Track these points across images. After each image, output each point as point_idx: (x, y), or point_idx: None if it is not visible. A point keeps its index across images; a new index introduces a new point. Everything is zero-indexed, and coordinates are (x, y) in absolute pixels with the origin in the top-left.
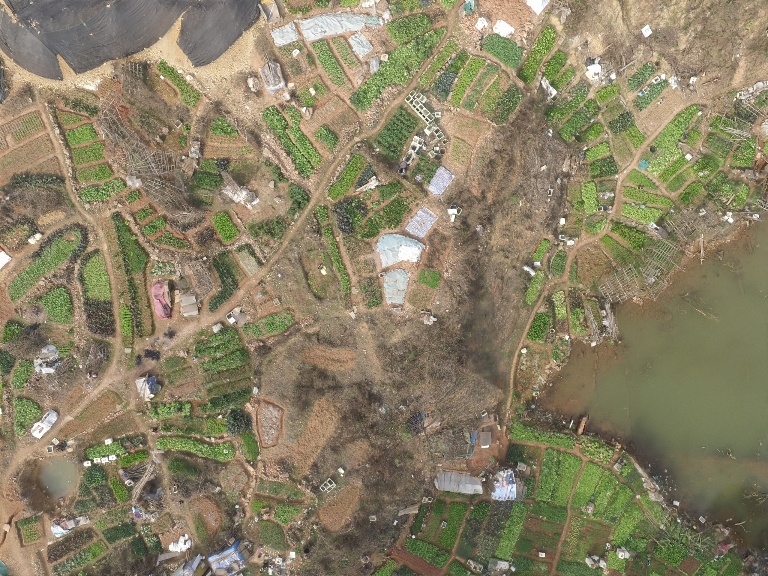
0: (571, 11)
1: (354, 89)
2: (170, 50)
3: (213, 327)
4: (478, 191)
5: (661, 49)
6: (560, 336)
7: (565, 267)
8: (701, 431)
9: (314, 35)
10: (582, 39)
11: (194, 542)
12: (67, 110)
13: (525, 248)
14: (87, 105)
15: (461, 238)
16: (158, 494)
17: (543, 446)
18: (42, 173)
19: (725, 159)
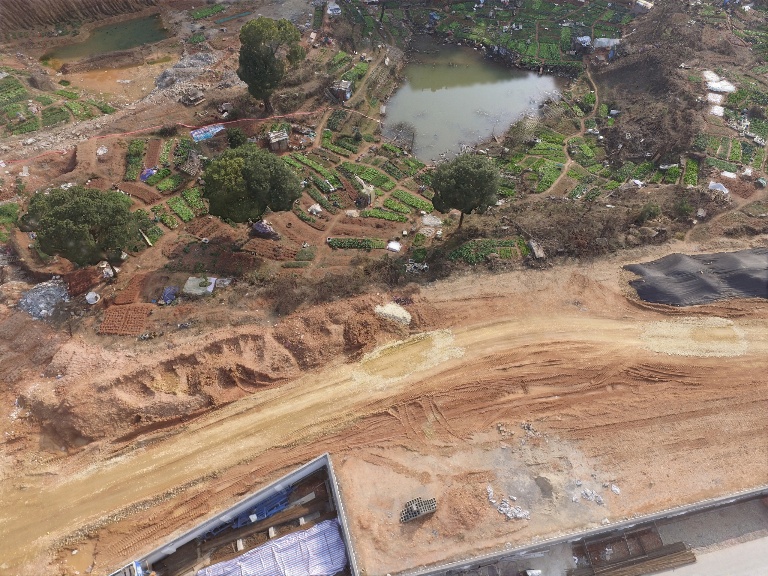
0: None
1: None
2: None
3: None
4: None
5: None
6: None
7: None
8: None
9: None
10: None
11: (742, 8)
12: None
13: None
14: None
15: None
16: None
17: None
18: None
19: None
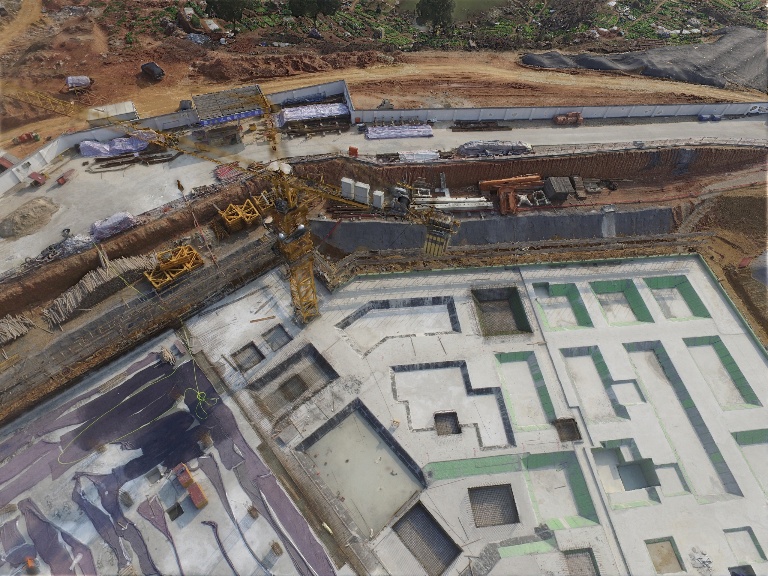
0: None
1: None
2: None
3: None
4: None
5: None
6: None
7: None
8: None
9: None
10: None
11: None
12: None
13: None
14: (763, 30)
15: None
16: None
17: None
18: None
19: None
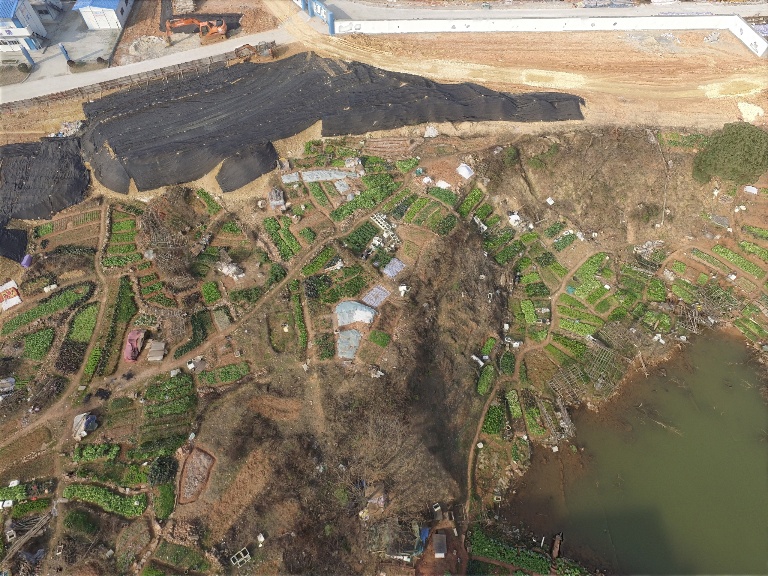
0: (491, 180)
1: (334, 209)
2: (209, 182)
3: (171, 371)
4: (425, 278)
5: (564, 213)
6: (518, 436)
7: (514, 368)
8: (706, 573)
9: (311, 179)
10: (502, 198)
11: None
12: (121, 211)
13: (472, 338)
14: (137, 209)
15: (410, 310)
16: (37, 556)
17: (511, 567)
18: (82, 246)
19: (641, 294)
